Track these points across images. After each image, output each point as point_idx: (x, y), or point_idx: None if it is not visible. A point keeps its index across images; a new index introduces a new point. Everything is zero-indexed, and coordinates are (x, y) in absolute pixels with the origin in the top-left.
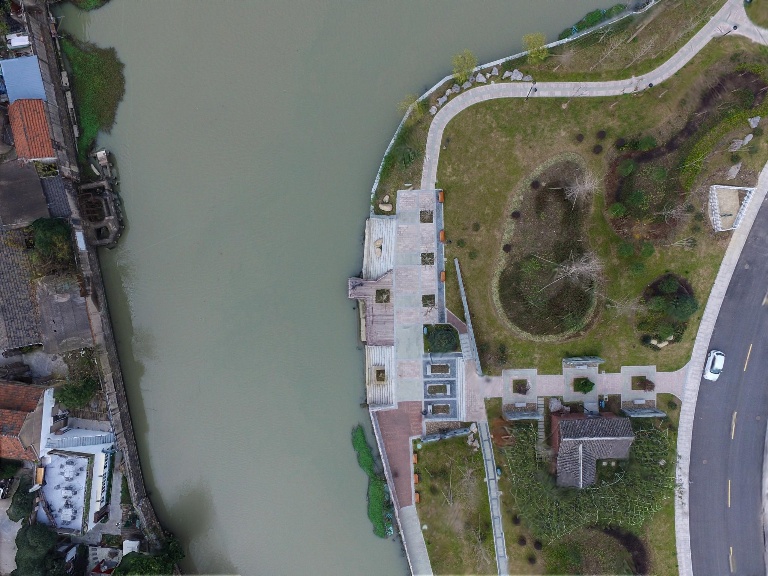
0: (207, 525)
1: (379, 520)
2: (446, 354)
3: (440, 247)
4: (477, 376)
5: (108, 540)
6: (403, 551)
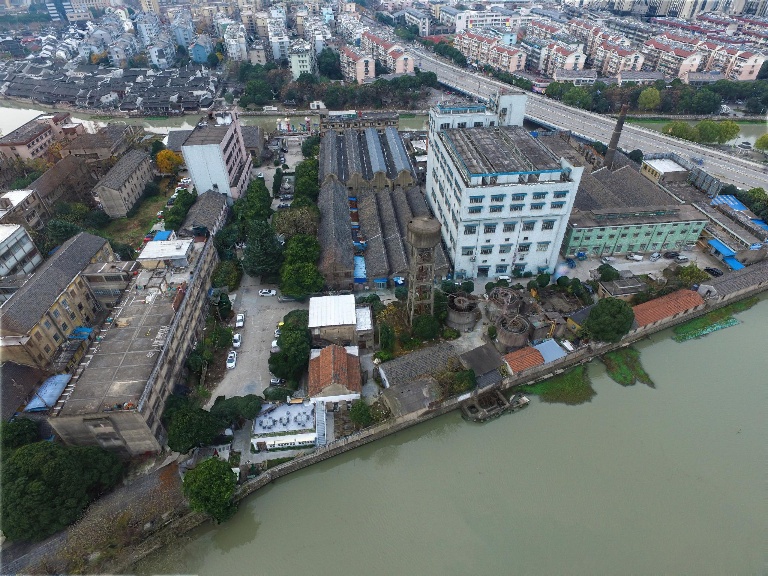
0: (227, 546)
1: None
2: None
3: None
4: None
5: (236, 457)
6: None
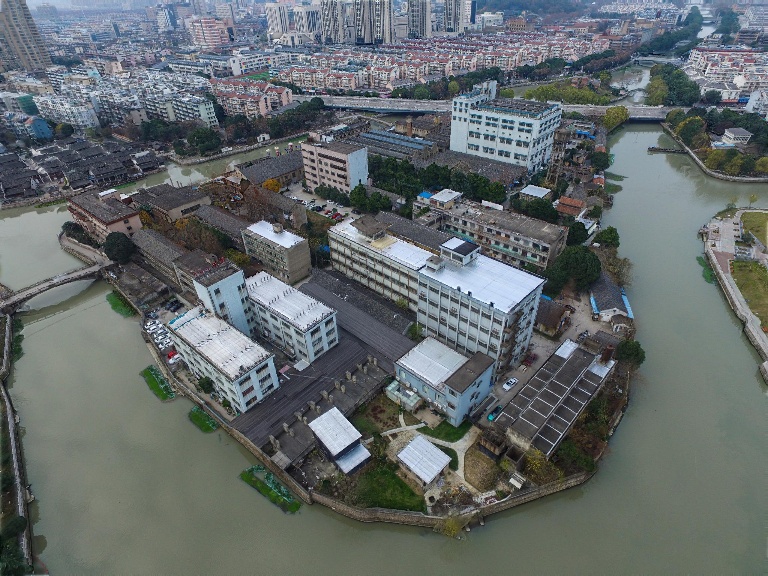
0: None
1: (709, 278)
2: (745, 247)
3: (742, 229)
4: (761, 253)
5: None
6: (721, 289)
